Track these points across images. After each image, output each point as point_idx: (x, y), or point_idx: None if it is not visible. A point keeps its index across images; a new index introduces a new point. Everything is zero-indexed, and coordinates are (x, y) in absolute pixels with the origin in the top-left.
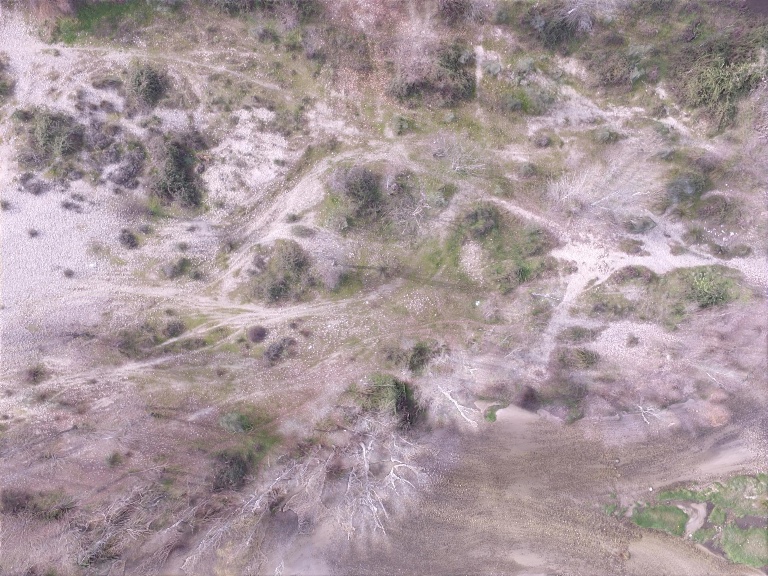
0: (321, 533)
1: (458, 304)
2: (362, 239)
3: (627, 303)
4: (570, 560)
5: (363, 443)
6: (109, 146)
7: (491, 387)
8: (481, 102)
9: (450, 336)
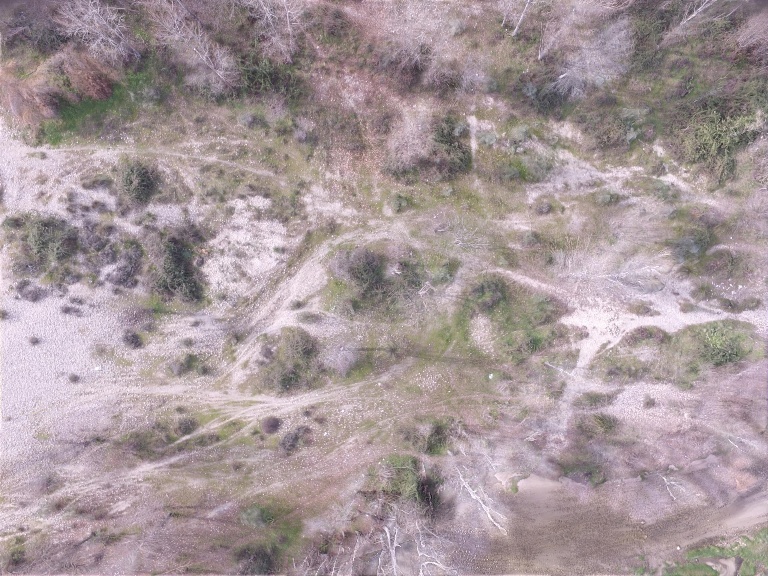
0: None
1: (471, 378)
2: (369, 321)
3: (641, 364)
4: None
5: (386, 527)
6: (105, 247)
7: (511, 459)
8: (478, 173)
9: (466, 411)
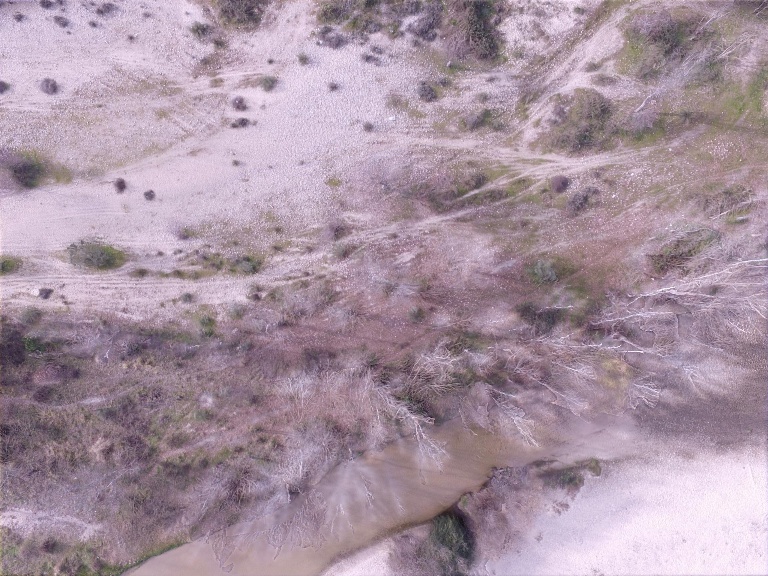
0: None
1: (762, 149)
2: (664, 86)
3: None
4: None
5: None
6: None
7: None
8: None
9: (756, 181)
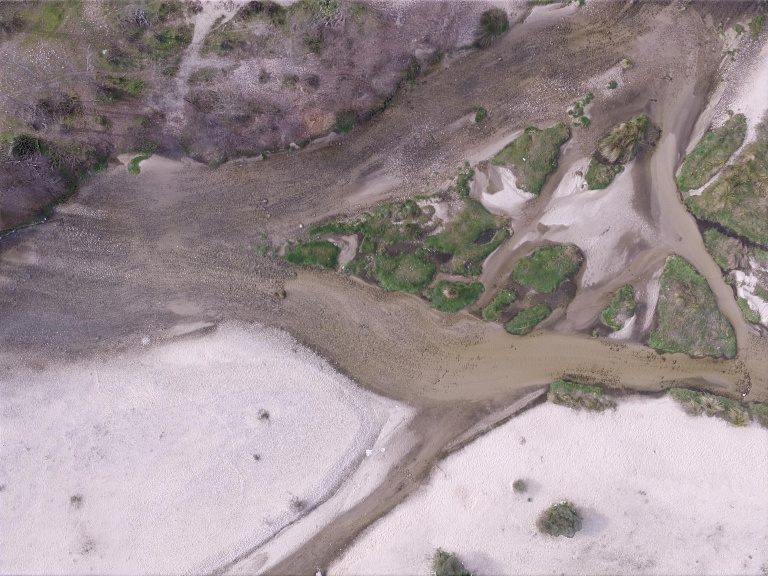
0: None
1: (86, 55)
2: None
3: (256, 39)
4: (227, 305)
5: None
6: None
7: (127, 136)
8: None
9: (80, 88)
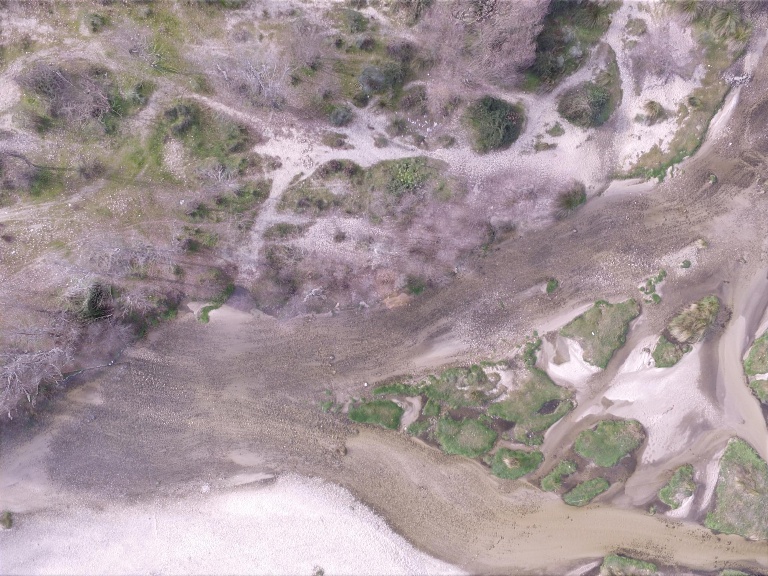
0: (39, 442)
1: (163, 204)
2: (61, 140)
3: (333, 197)
4: (288, 458)
5: None
6: None
7: (199, 287)
8: None
9: (155, 236)
